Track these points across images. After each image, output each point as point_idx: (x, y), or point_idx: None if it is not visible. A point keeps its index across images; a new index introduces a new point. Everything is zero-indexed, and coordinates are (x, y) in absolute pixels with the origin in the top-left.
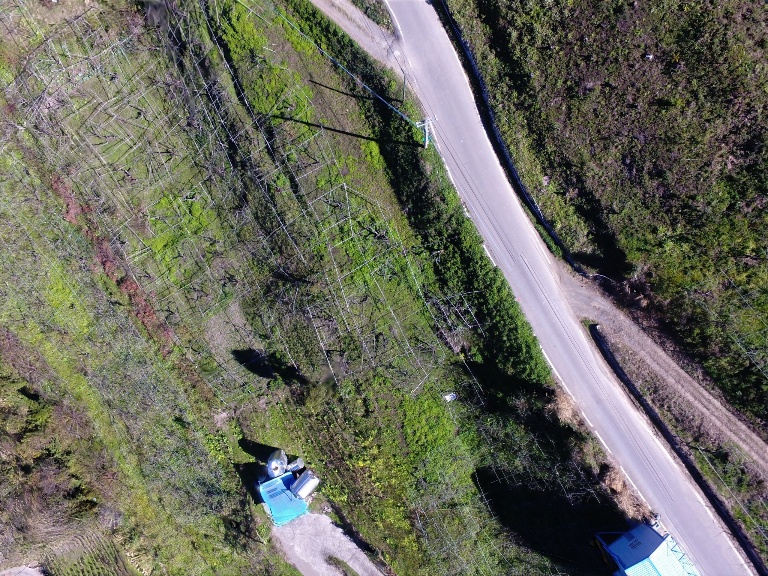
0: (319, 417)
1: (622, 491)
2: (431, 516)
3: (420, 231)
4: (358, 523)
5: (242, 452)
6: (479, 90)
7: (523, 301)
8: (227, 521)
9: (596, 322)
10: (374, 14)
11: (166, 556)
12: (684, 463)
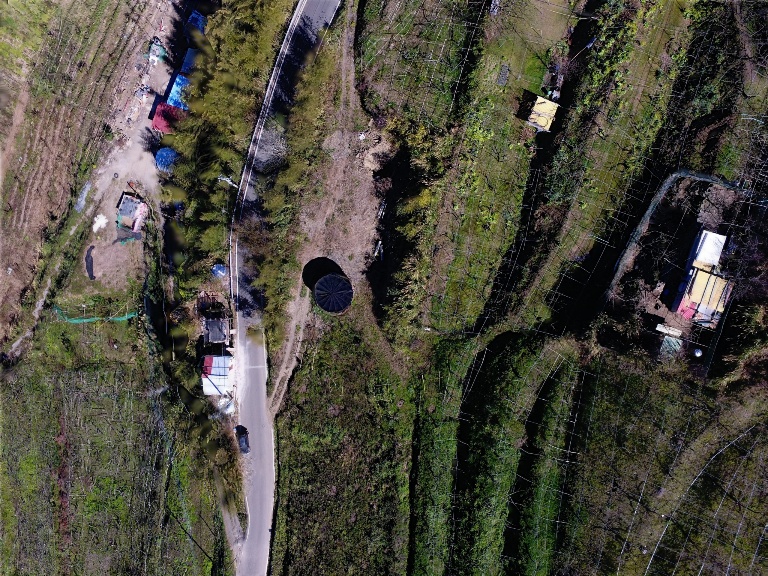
0: None
1: None
2: None
3: None
4: None
5: None
6: None
7: None
8: None
9: None
10: (240, 520)
11: None
12: None
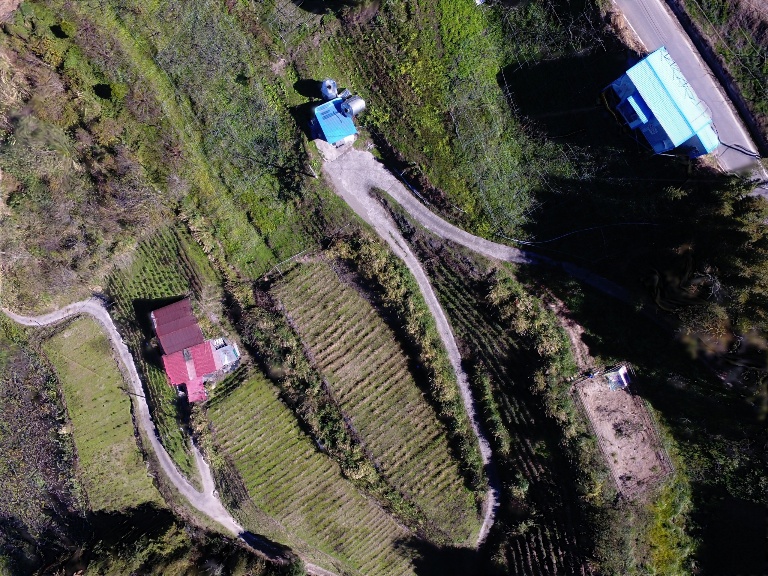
0: (366, 37)
1: None
2: None
3: None
4: (398, 141)
5: (297, 94)
6: None
7: None
8: (282, 174)
9: None
10: None
11: (224, 231)
12: (676, 15)
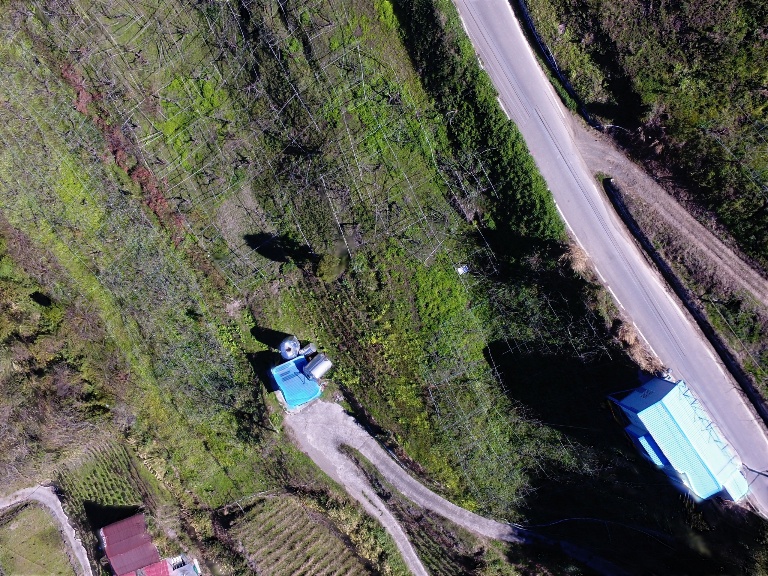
0: (332, 297)
1: (635, 344)
2: (443, 390)
3: (434, 93)
4: (370, 405)
5: (254, 341)
6: None
7: (537, 155)
8: (240, 415)
9: (610, 176)
10: None
11: (179, 458)
12: (696, 320)
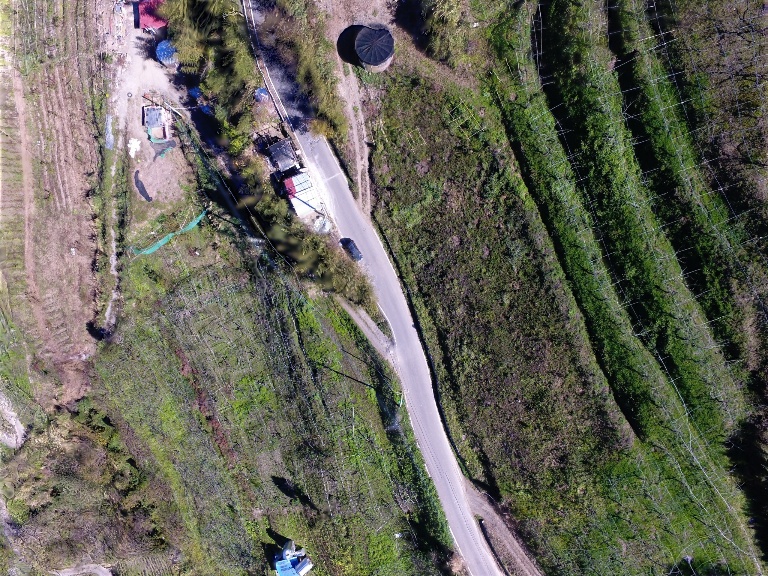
0: None
1: None
2: None
3: (392, 443)
4: None
5: (268, 536)
6: (434, 380)
7: (443, 499)
8: (251, 574)
9: (483, 518)
10: (382, 329)
11: None
12: None
